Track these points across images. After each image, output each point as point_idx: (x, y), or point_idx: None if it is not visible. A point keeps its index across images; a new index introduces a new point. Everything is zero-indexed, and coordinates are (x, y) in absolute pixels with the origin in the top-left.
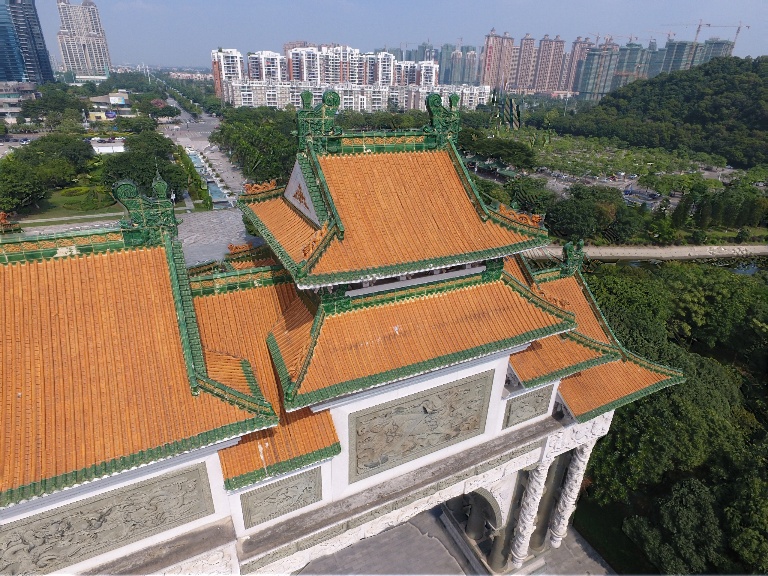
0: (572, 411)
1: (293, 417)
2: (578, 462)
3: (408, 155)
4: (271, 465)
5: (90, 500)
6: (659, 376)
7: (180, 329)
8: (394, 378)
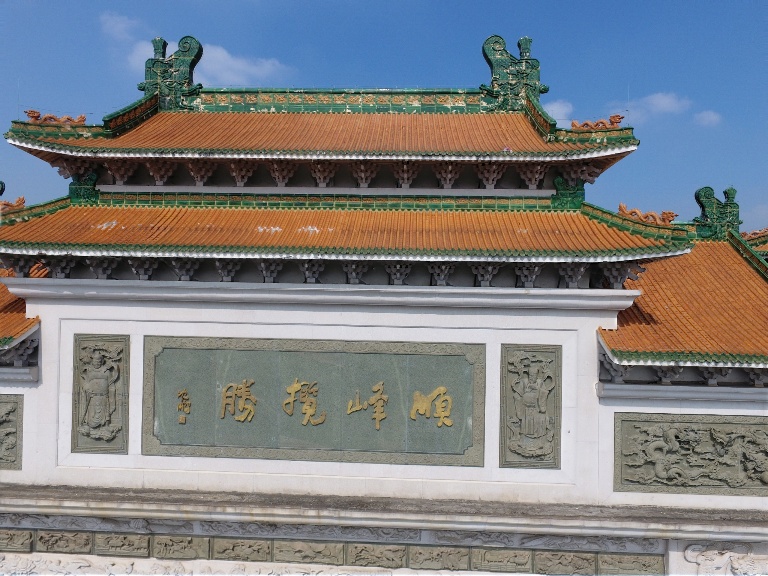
0: None
1: None
2: None
3: None
4: None
5: (721, 419)
6: None
7: None
8: None
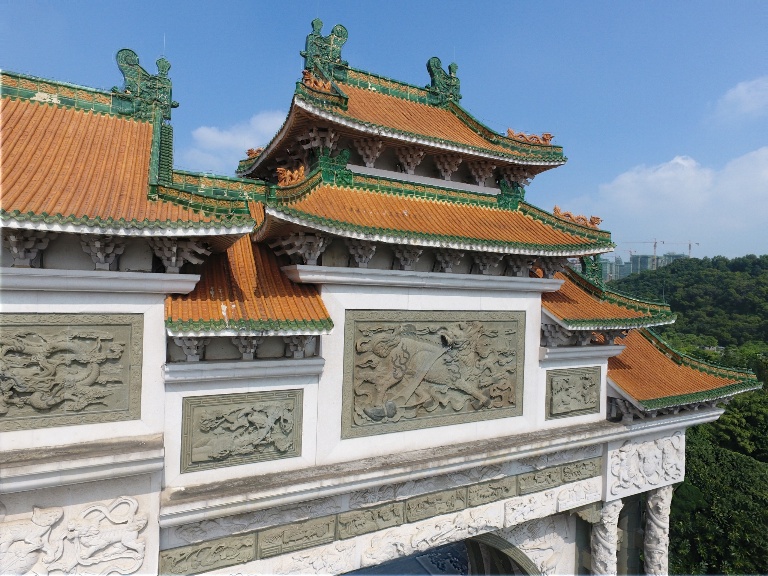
0: (632, 396)
1: (272, 293)
2: (655, 529)
3: (412, 103)
4: (235, 320)
5: None
6: (727, 381)
7: (151, 157)
8: (404, 235)
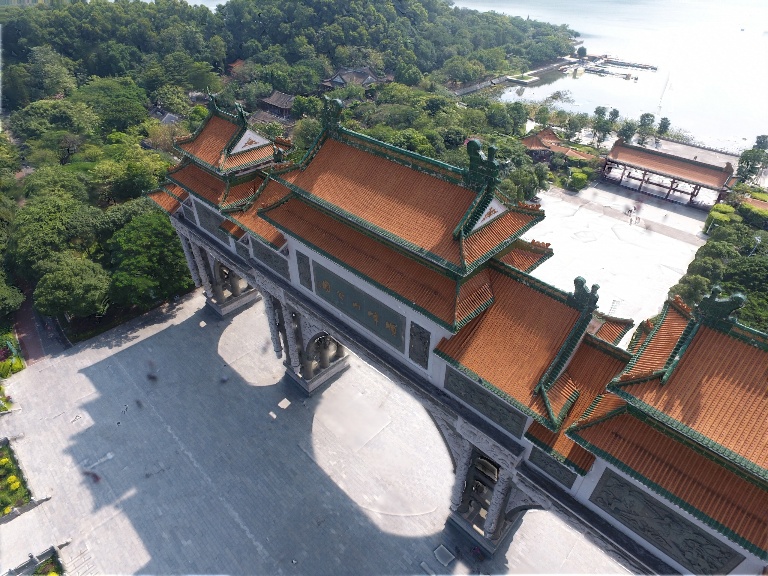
0: None
1: None
2: None
3: None
4: None
5: None
6: None
7: None
8: None
